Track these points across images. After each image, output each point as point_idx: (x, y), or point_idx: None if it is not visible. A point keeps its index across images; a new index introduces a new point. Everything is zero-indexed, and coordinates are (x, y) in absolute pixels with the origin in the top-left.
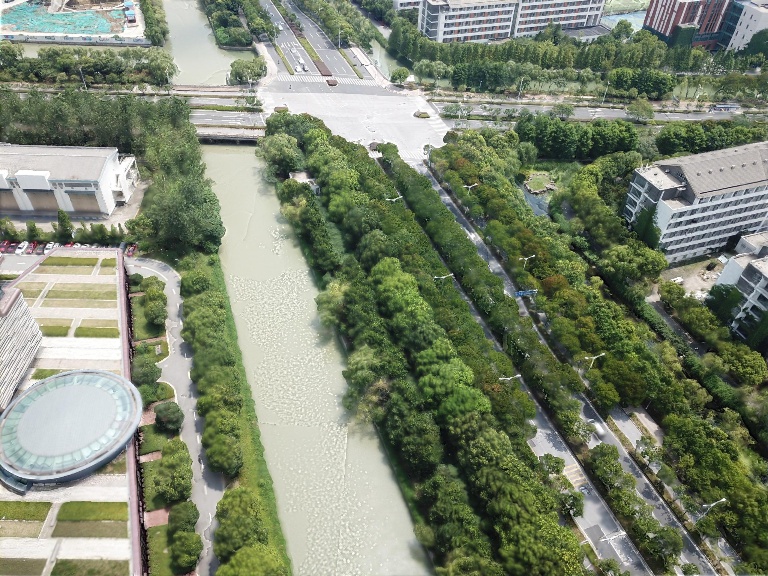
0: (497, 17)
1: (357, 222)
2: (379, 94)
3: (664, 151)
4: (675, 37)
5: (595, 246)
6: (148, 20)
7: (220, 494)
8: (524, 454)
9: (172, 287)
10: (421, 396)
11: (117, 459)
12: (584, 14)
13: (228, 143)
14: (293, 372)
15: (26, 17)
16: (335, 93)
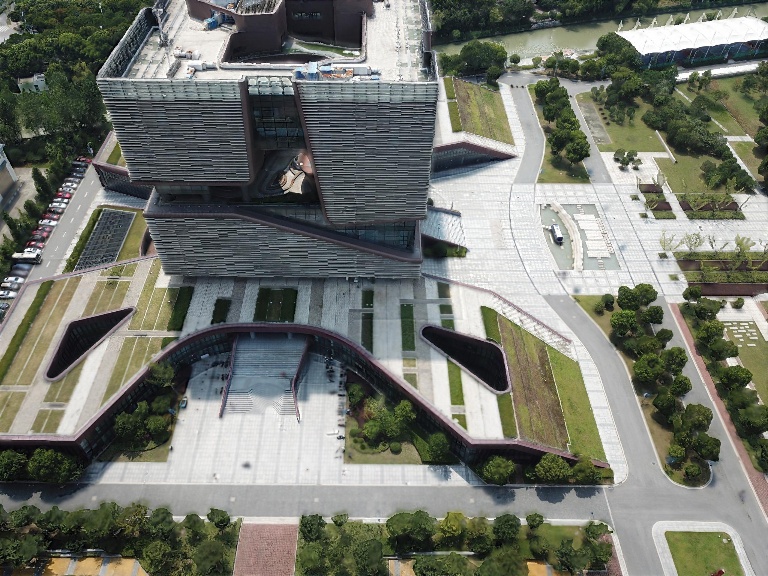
0: None
1: None
2: None
3: None
4: None
5: None
6: None
7: None
8: None
9: None
10: None
11: None
12: None
13: None
14: None
15: None
16: None
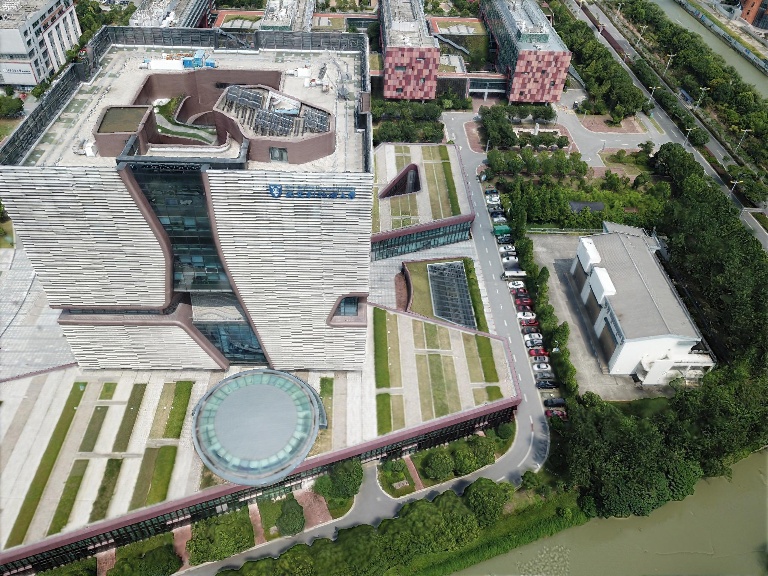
0: None
1: None
2: None
3: None
4: None
5: None
6: None
7: None
8: None
9: (508, 475)
10: None
11: (217, 478)
12: None
13: None
14: None
15: None
16: None
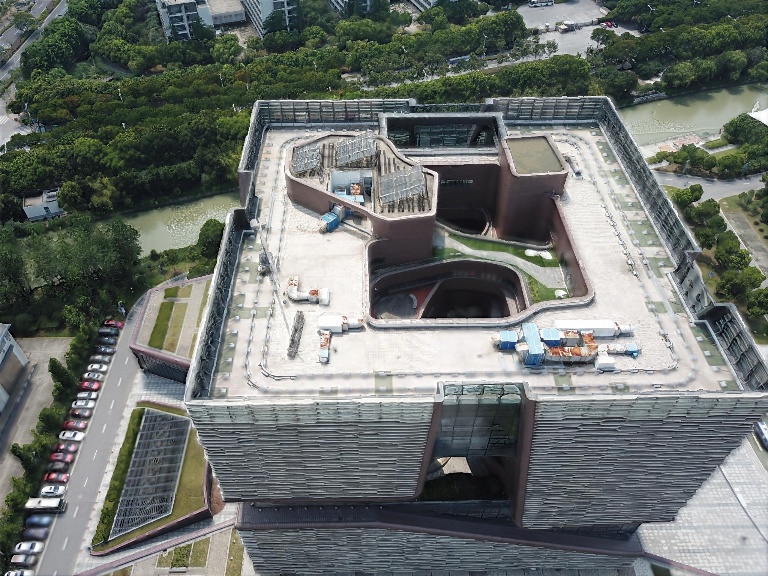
0: None
1: (165, 136)
2: None
3: (91, 24)
4: None
5: None
6: None
7: None
8: None
9: None
10: None
11: None
12: None
13: None
14: None
15: None
16: None
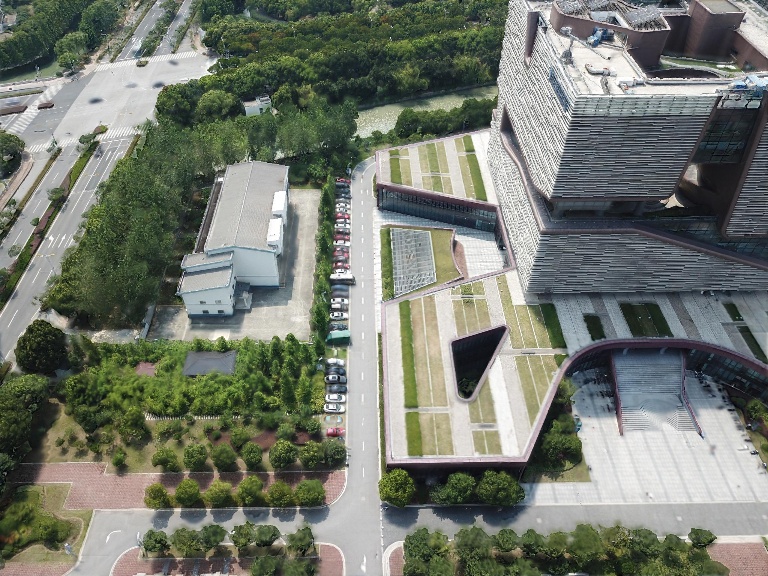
0: None
1: (349, 56)
2: (86, 83)
3: None
4: None
5: None
6: None
7: None
8: None
9: None
10: None
11: None
12: None
13: None
14: None
15: None
16: (72, 104)
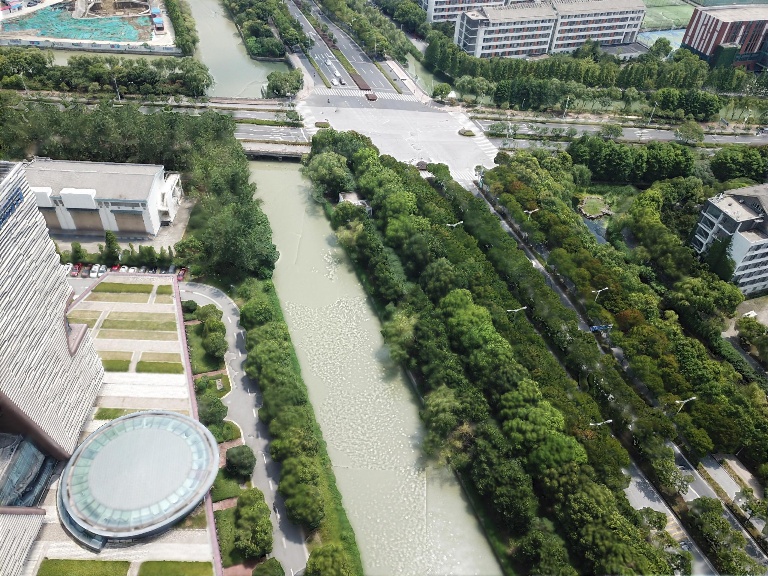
0: (536, 33)
1: (422, 250)
2: (420, 110)
3: (719, 176)
4: (716, 57)
5: (661, 276)
6: (179, 28)
7: (300, 548)
8: (627, 509)
9: (227, 315)
10: (508, 442)
11: (195, 512)
12: (621, 31)
13: (270, 159)
14: (361, 409)
15: (50, 22)
16: (375, 108)
